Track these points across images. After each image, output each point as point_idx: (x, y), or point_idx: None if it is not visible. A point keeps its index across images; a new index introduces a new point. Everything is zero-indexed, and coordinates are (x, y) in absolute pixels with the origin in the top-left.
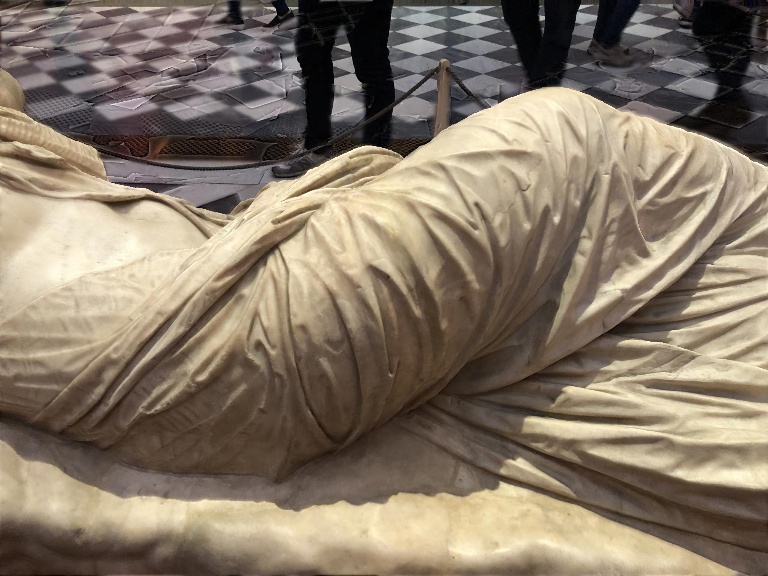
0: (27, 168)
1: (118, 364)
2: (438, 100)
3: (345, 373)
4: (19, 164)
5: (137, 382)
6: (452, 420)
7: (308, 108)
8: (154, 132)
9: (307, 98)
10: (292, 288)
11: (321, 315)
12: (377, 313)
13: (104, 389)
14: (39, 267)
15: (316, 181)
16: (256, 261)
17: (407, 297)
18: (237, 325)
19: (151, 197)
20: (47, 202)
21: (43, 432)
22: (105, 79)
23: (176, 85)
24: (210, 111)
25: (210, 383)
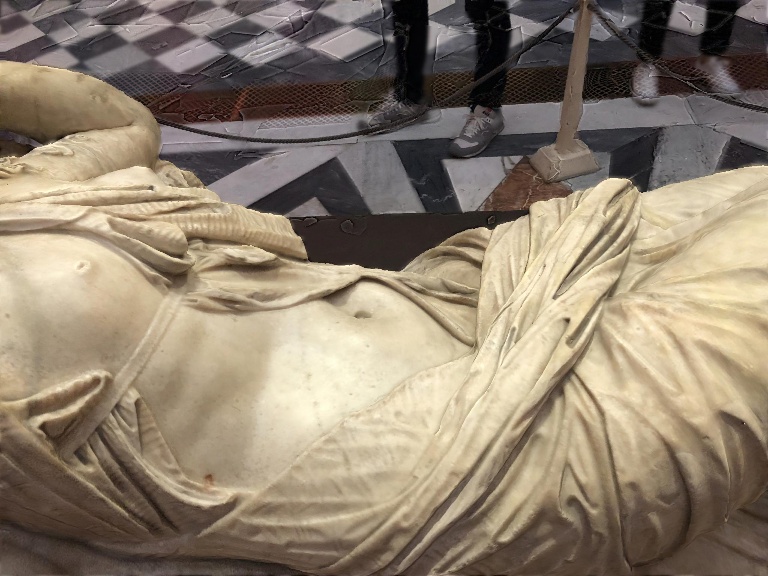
0: (243, 278)
1: (410, 532)
2: (573, 42)
3: (672, 522)
4: (235, 276)
5: (429, 546)
6: (739, 514)
7: (408, 54)
8: (248, 103)
9: (408, 44)
10: (614, 436)
11: (654, 469)
12: (726, 465)
13: (393, 556)
14: (290, 412)
15: (578, 257)
16: (550, 392)
17: (761, 442)
18: (541, 476)
19: (365, 277)
20: (272, 317)
21: (301, 572)
22: (190, 48)
23: (272, 51)
24: (305, 72)
25: (512, 541)
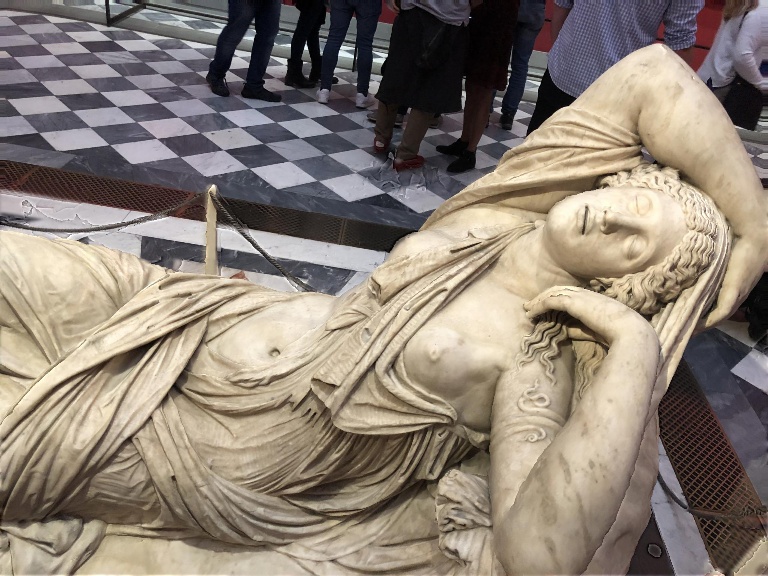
0: None
1: None
2: None
3: None
4: None
5: None
6: None
7: None
8: None
9: None
10: None
11: None
12: None
13: None
14: None
15: None
16: None
17: None
18: None
19: None
20: None
21: None
22: None
23: None
24: None
25: None
